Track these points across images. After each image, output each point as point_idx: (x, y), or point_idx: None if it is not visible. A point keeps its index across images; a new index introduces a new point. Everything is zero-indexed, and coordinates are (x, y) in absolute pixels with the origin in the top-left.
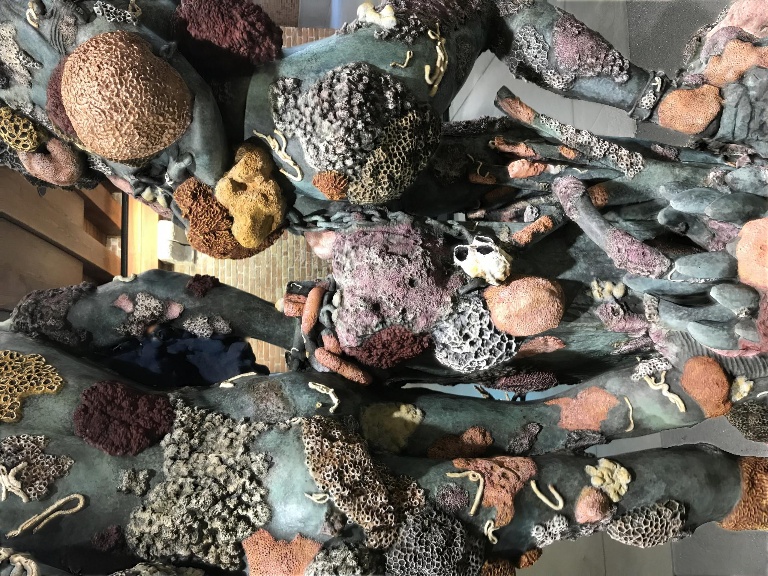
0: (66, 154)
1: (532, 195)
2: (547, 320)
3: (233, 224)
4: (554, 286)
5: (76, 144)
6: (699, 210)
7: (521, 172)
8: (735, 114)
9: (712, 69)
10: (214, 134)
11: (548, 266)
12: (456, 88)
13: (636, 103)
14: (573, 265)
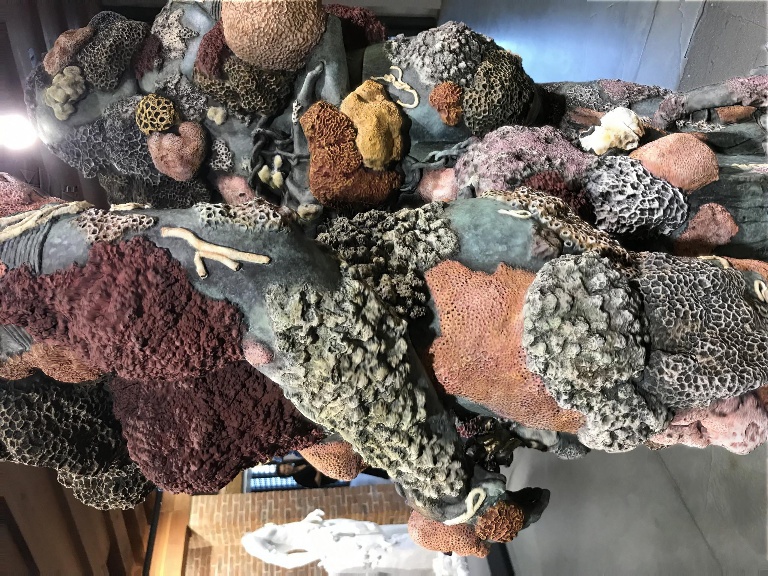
0: (196, 129)
1: None
2: (704, 157)
3: (357, 135)
4: None
5: (209, 112)
6: None
7: None
8: None
9: None
10: (342, 49)
11: None
12: None
13: None
14: None
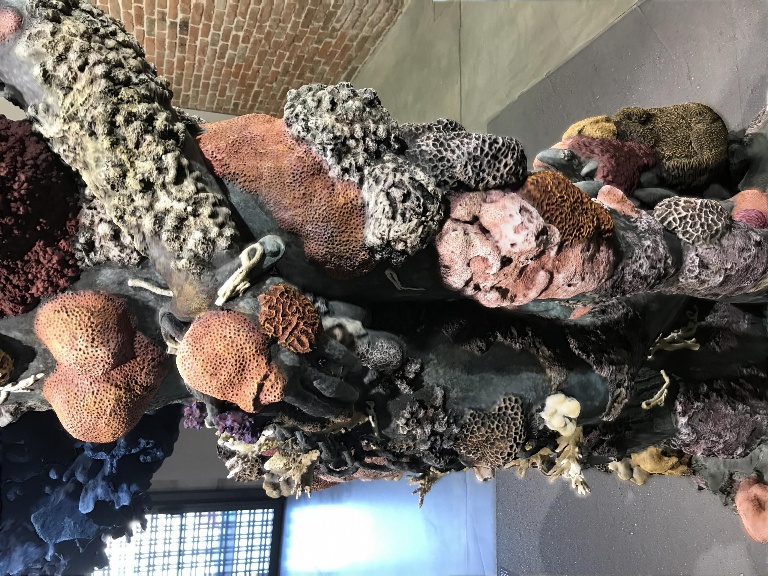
0: None
1: None
2: None
3: None
4: None
5: None
6: None
7: None
8: None
9: None
10: None
11: None
12: None
13: None
14: None
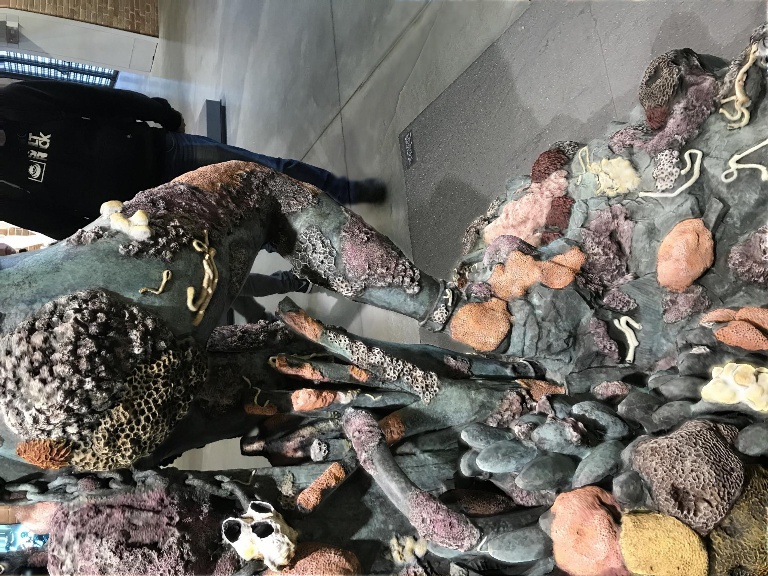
0: None
1: (319, 419)
2: None
3: None
4: (349, 562)
5: None
6: (506, 470)
7: (307, 405)
8: (524, 333)
9: (498, 279)
10: None
11: (340, 524)
12: (229, 302)
13: (428, 316)
14: (369, 518)
